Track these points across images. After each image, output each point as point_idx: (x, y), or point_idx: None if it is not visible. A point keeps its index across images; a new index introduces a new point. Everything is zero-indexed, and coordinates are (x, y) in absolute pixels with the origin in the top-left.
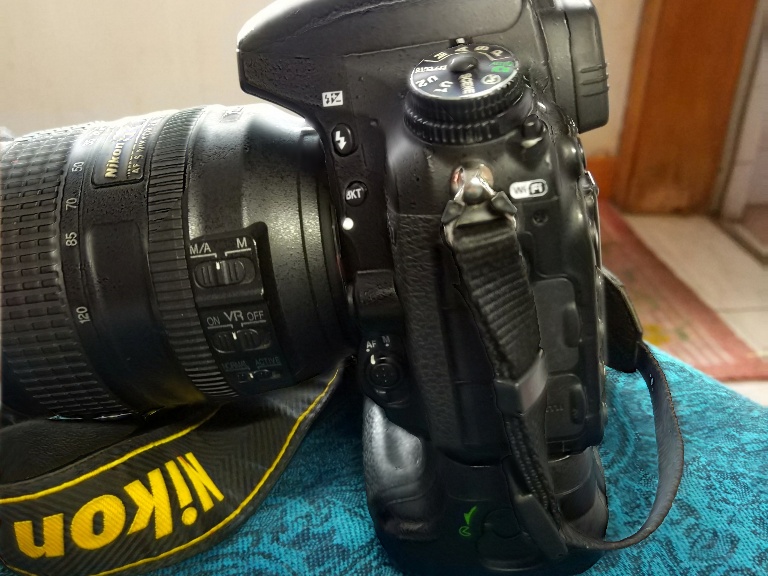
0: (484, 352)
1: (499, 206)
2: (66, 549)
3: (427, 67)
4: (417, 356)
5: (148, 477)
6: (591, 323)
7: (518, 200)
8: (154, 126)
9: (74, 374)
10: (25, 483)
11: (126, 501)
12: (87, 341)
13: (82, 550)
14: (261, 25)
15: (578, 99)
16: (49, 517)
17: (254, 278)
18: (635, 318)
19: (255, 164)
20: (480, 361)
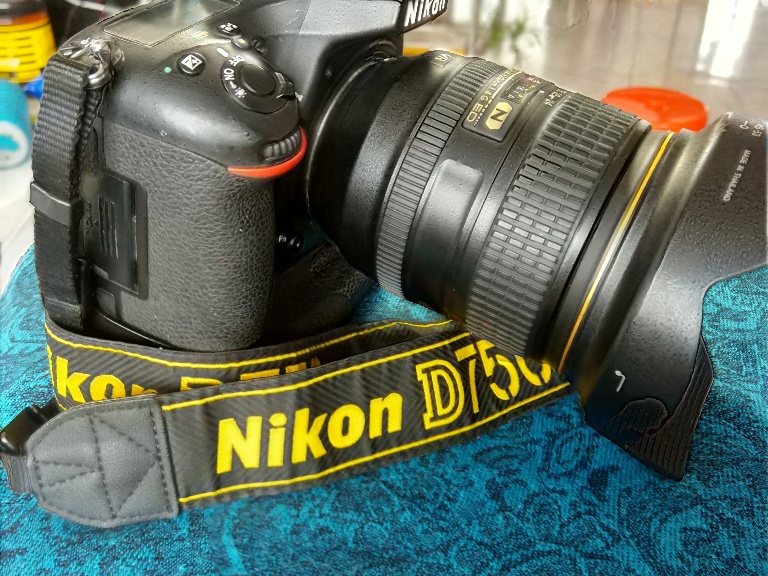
0: None
1: None
2: None
3: None
4: None
5: None
6: None
7: None
8: None
9: None
10: None
11: None
12: None
13: None
14: None
15: None
16: None
17: None
18: None
19: None
20: None
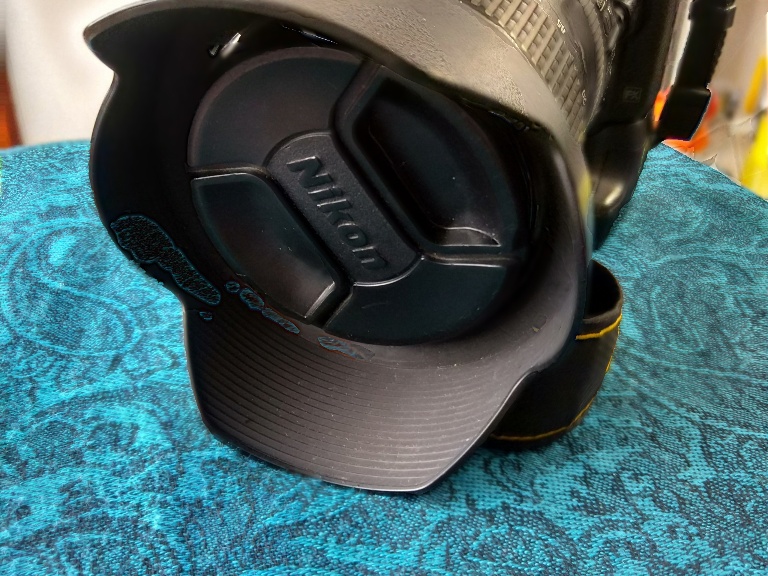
0: None
1: None
2: None
3: None
4: (663, 34)
5: None
6: None
7: None
8: None
9: None
10: None
11: None
12: None
13: None
14: None
15: None
16: None
17: None
18: None
19: None
20: None
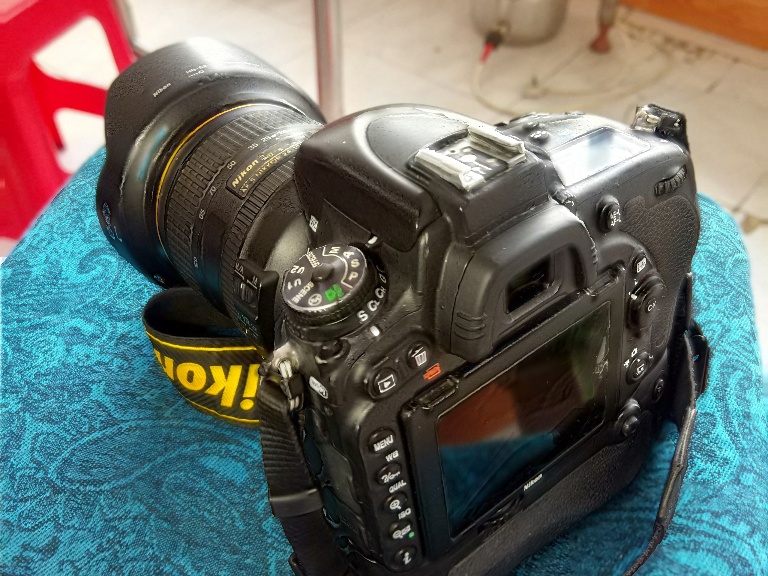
0: (316, 459)
1: (282, 388)
2: (175, 378)
3: (314, 256)
4: None
5: (230, 368)
6: (367, 498)
7: (313, 389)
8: (284, 157)
9: (197, 289)
10: (158, 333)
11: (208, 375)
12: (198, 277)
13: (182, 385)
14: (316, 136)
15: (452, 333)
16: (167, 357)
17: (256, 306)
18: (664, 503)
19: (296, 228)
20: (315, 462)
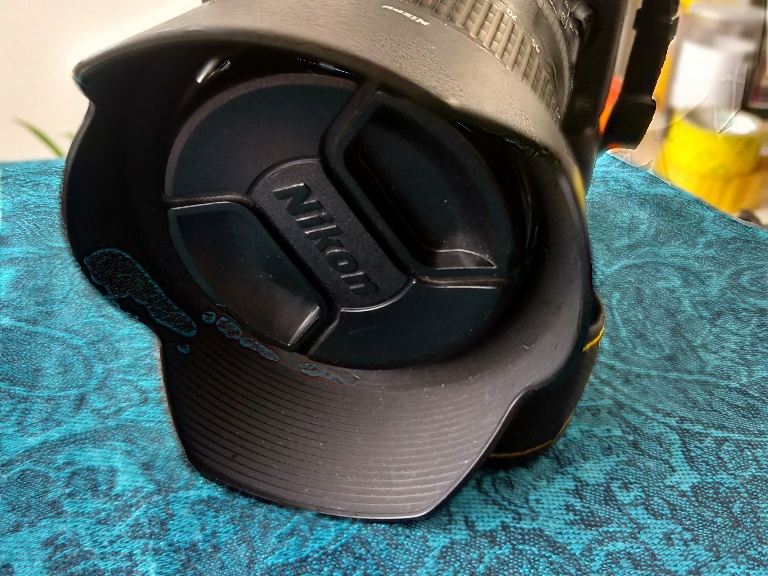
0: None
1: None
2: None
3: None
4: None
5: None
6: None
7: None
8: None
9: None
10: None
11: None
12: None
13: None
14: None
15: None
16: None
17: None
18: None
19: None
20: None
